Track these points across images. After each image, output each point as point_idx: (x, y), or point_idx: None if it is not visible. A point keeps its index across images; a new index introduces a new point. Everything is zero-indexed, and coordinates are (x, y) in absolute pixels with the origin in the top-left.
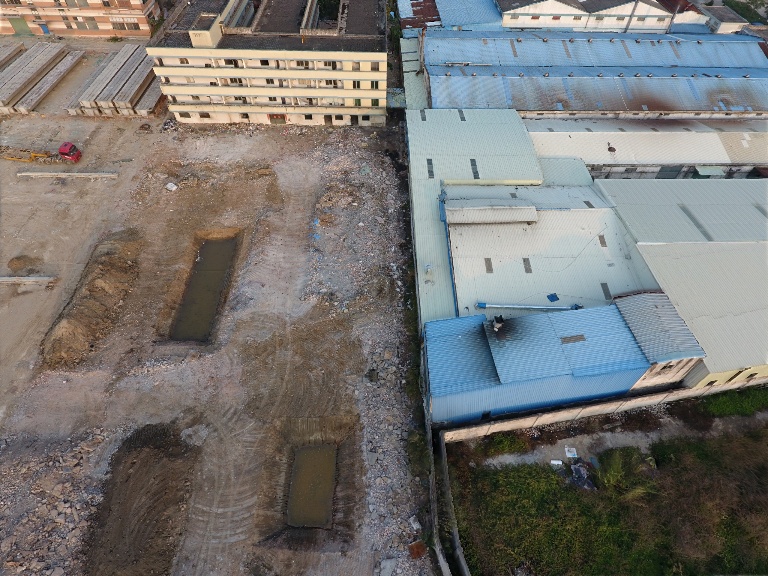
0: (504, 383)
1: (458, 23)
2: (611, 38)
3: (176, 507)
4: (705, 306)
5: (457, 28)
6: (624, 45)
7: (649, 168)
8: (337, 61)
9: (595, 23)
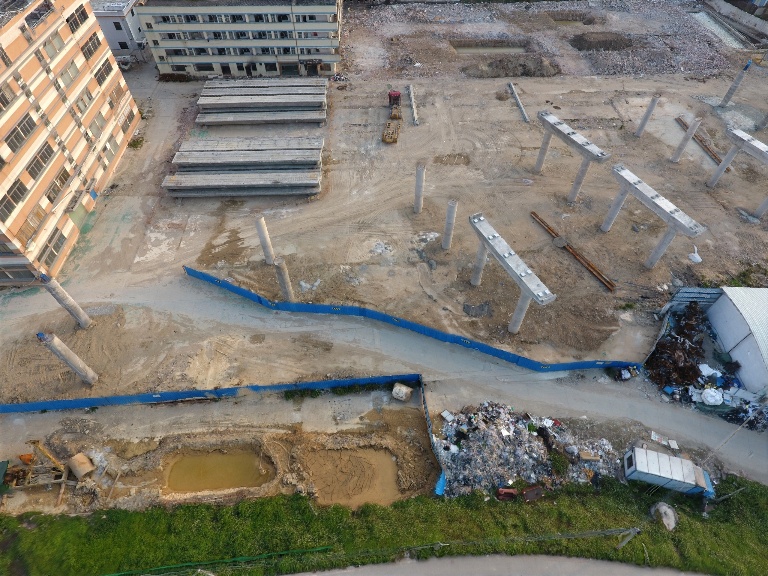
0: None
1: None
2: None
3: None
4: None
5: None
6: None
7: None
8: None
9: None
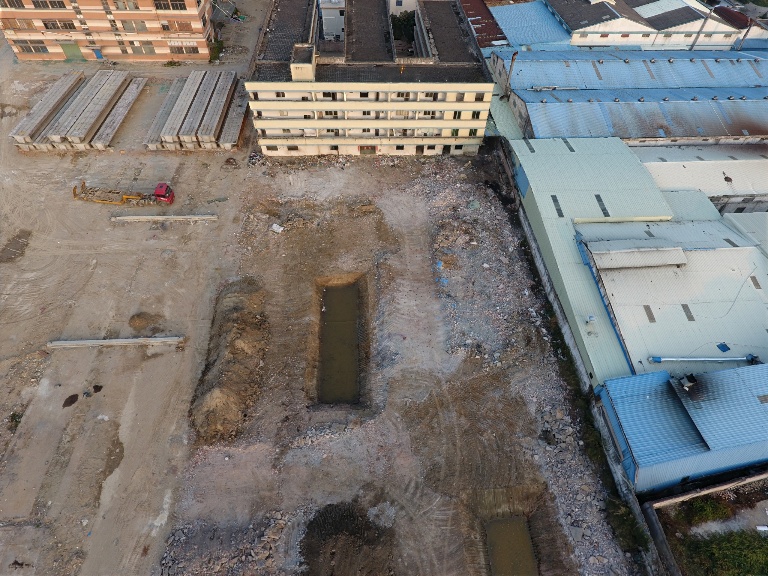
0: (713, 450)
1: (526, 42)
2: (690, 58)
3: None
4: None
5: (526, 47)
6: (705, 65)
7: (766, 198)
8: (441, 92)
9: (662, 40)
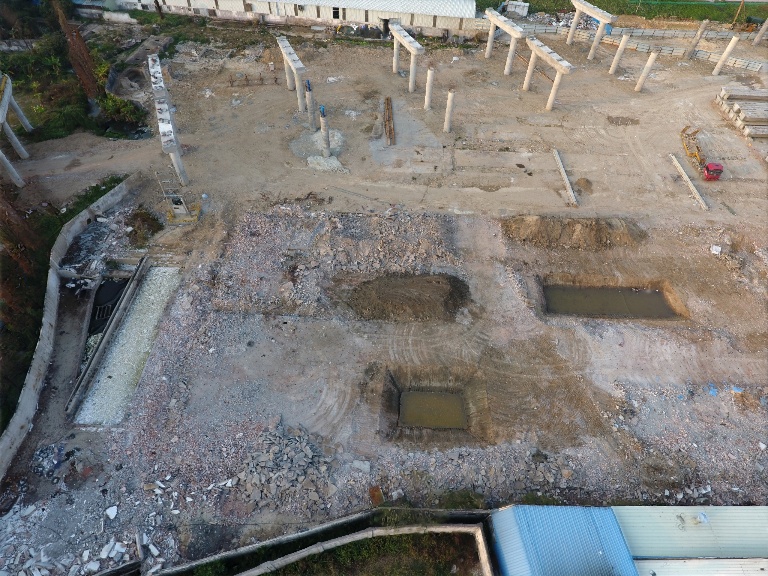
0: None
1: None
2: None
3: (412, 314)
4: None
5: None
6: None
7: None
8: None
9: None
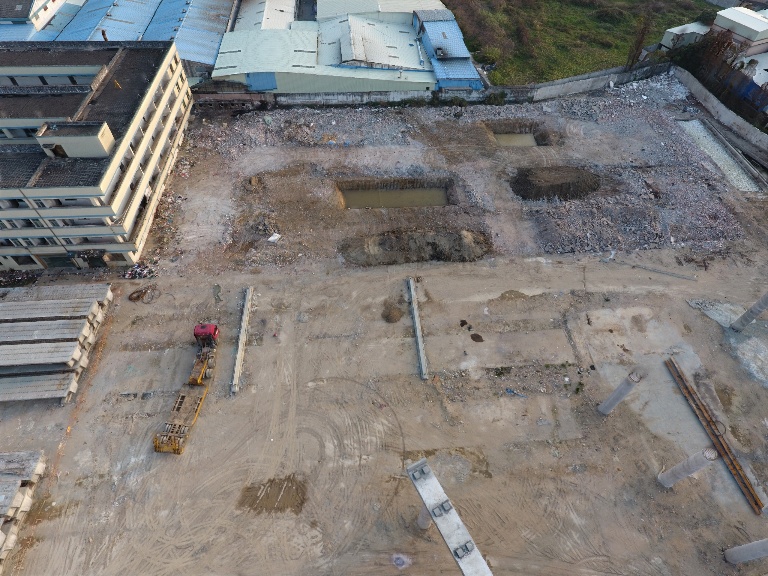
0: None
1: None
2: None
3: None
4: (417, 6)
5: None
6: None
7: (295, 8)
8: None
9: None
